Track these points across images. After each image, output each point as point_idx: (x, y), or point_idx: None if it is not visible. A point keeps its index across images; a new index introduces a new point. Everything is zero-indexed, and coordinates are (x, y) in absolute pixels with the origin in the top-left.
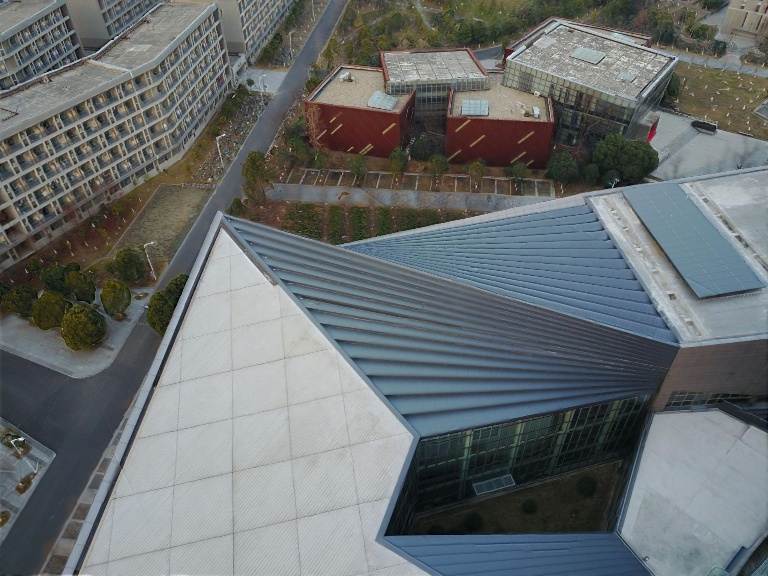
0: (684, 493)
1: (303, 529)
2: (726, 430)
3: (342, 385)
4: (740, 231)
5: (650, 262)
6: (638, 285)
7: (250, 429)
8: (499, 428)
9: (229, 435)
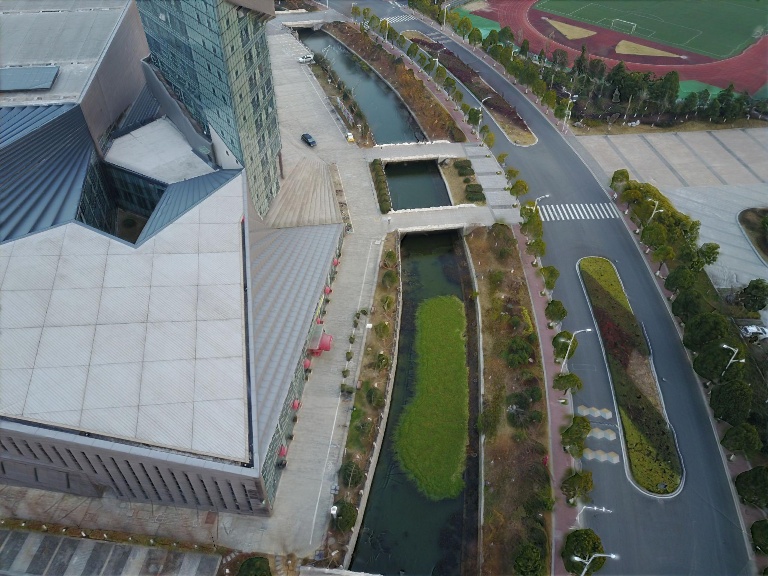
0: (157, 161)
1: (111, 284)
2: (128, 140)
3: (2, 256)
4: (7, 64)
5: (3, 100)
6: (19, 108)
7: (7, 316)
8: (83, 200)
9: (5, 331)
